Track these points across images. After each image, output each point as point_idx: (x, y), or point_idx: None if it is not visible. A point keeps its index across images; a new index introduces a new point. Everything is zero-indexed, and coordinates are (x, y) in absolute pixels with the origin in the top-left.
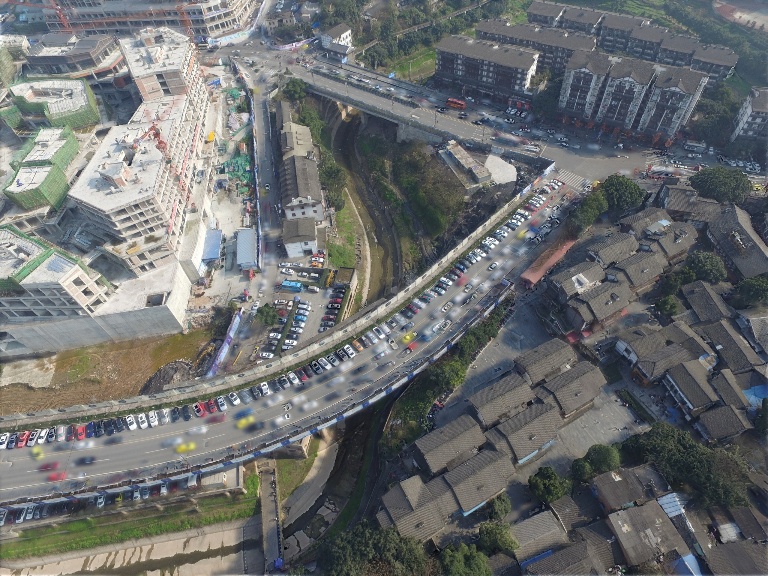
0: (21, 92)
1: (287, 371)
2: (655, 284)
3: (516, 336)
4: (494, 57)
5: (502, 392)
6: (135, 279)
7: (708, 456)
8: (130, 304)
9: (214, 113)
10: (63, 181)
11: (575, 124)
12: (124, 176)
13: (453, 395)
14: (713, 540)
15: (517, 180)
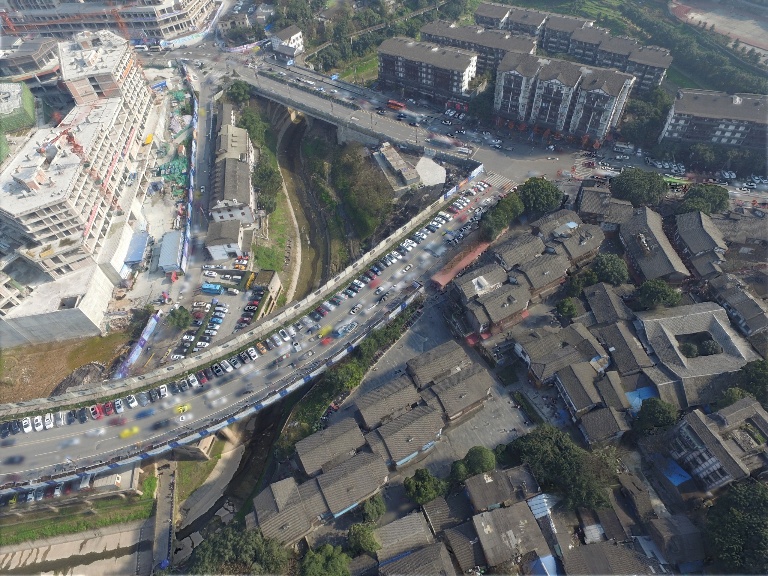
0: None
1: (188, 373)
2: (560, 286)
3: (421, 338)
4: (431, 59)
5: (387, 394)
6: (52, 282)
7: (579, 458)
8: (43, 307)
9: (156, 115)
10: None
11: (508, 126)
12: (37, 180)
13: (350, 397)
14: (577, 541)
15: (445, 182)
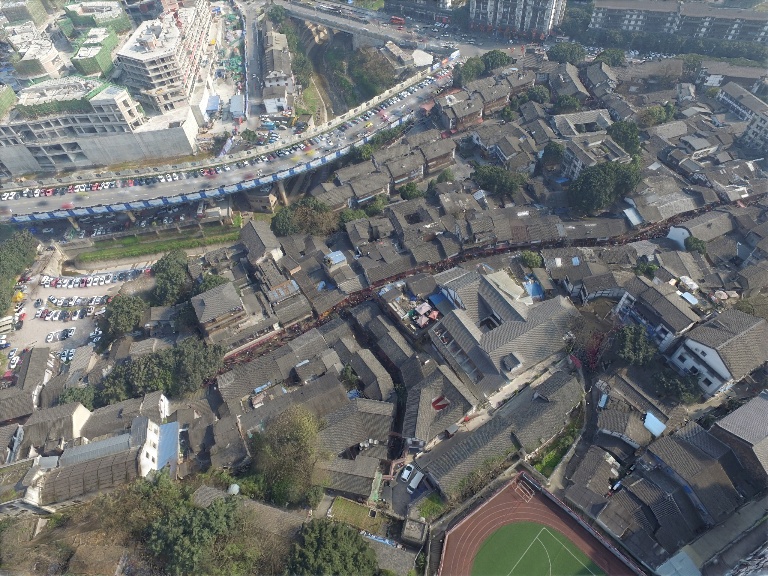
0: (74, 9)
1: (260, 156)
2: None
3: None
4: None
5: None
6: (161, 115)
7: None
8: (158, 127)
9: (215, 29)
10: (109, 58)
11: (480, 28)
12: (154, 42)
13: None
14: None
15: (432, 63)
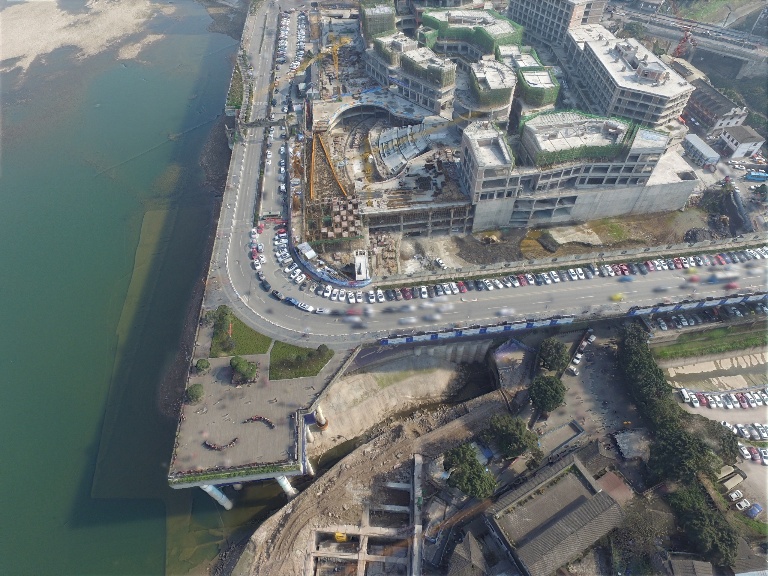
0: (441, 18)
1: None
2: None
3: None
4: None
5: None
6: None
7: None
8: (668, 178)
9: None
10: None
11: None
12: None
13: None
14: None
15: None
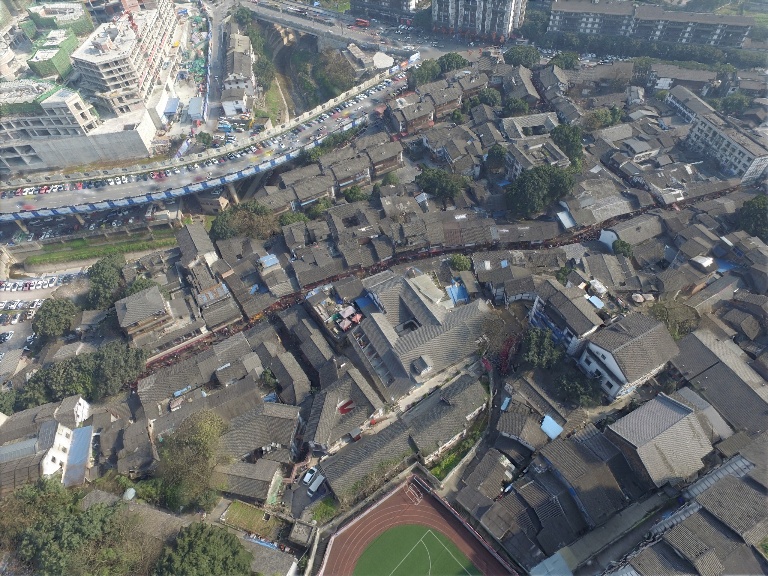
0: (36, 10)
1: None
2: (457, 109)
3: None
4: None
5: None
6: (116, 118)
7: None
8: (112, 129)
9: (180, 31)
10: (67, 61)
11: (441, 30)
12: (108, 45)
13: None
14: None
15: (392, 66)
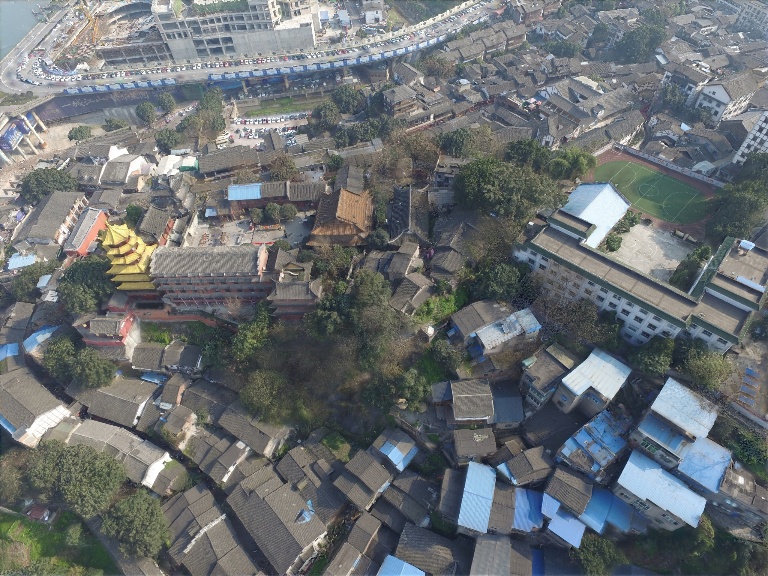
0: None
1: None
2: None
3: None
4: None
5: None
6: (291, 20)
7: None
8: (292, 26)
9: None
10: None
11: None
12: None
13: None
14: None
15: None
